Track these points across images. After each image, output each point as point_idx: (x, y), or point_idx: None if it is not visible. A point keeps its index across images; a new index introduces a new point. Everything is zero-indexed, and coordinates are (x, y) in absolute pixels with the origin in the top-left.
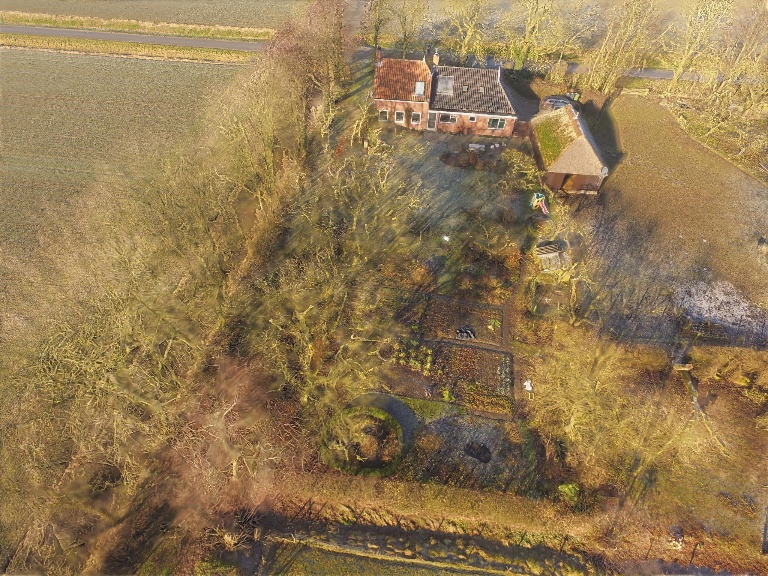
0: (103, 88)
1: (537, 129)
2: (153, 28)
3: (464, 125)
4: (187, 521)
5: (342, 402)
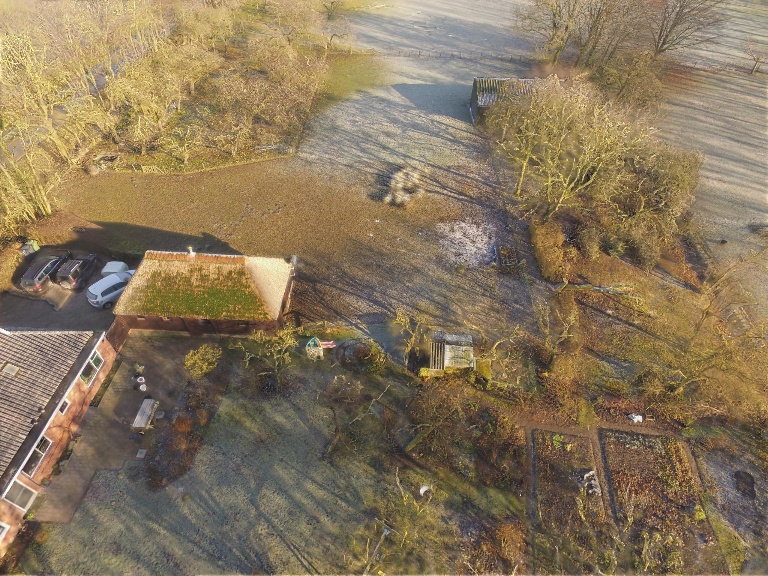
0: None
1: (155, 311)
2: None
3: (63, 427)
4: None
5: None
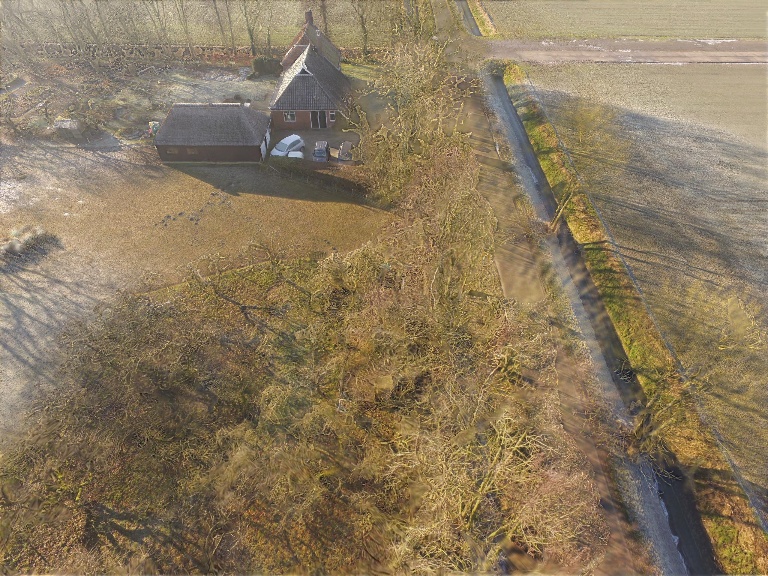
0: (345, 2)
1: None
2: (472, 2)
3: None
4: (3, 62)
5: None
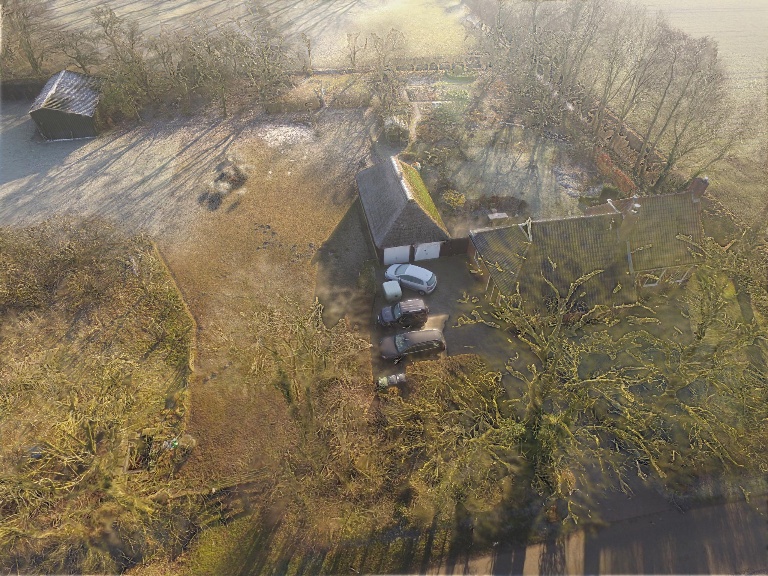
0: None
1: None
2: None
3: None
4: None
5: (478, 81)
